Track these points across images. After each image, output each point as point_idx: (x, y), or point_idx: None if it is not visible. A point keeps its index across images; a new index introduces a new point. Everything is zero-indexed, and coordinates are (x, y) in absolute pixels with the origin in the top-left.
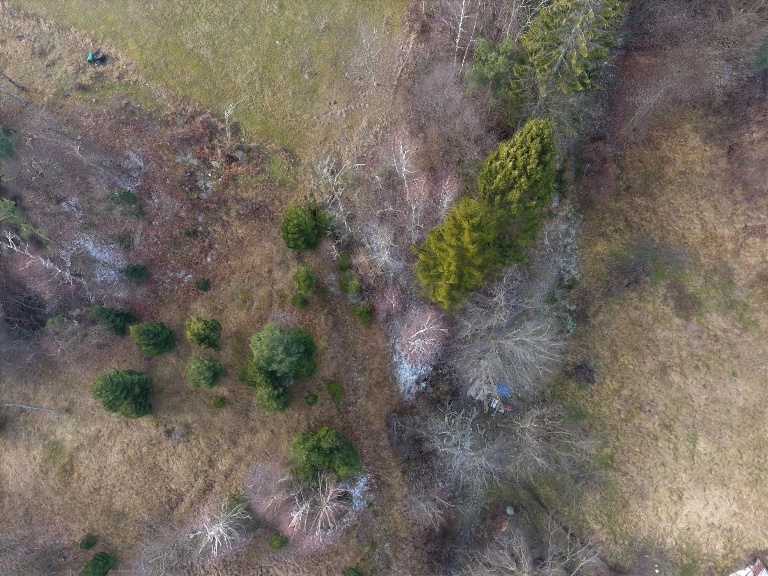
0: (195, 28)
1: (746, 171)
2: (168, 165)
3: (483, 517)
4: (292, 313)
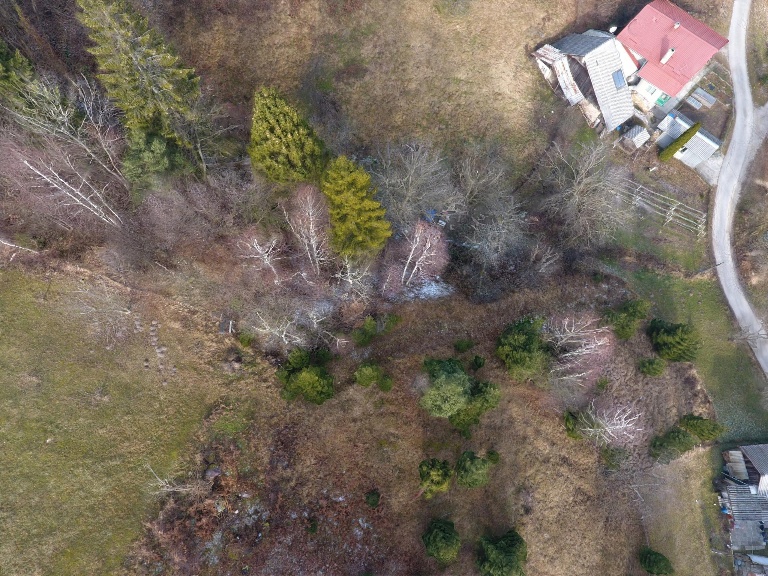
0: (6, 569)
1: (242, 4)
2: (222, 573)
3: (530, 235)
4: (397, 391)
